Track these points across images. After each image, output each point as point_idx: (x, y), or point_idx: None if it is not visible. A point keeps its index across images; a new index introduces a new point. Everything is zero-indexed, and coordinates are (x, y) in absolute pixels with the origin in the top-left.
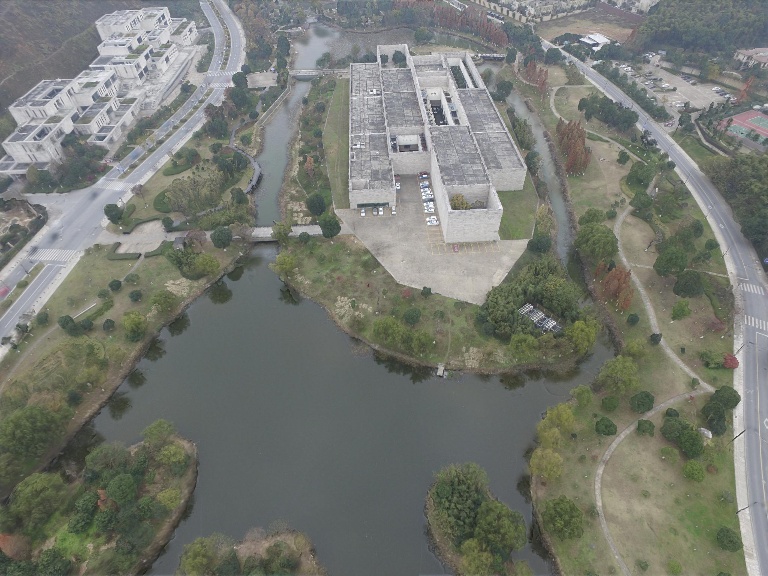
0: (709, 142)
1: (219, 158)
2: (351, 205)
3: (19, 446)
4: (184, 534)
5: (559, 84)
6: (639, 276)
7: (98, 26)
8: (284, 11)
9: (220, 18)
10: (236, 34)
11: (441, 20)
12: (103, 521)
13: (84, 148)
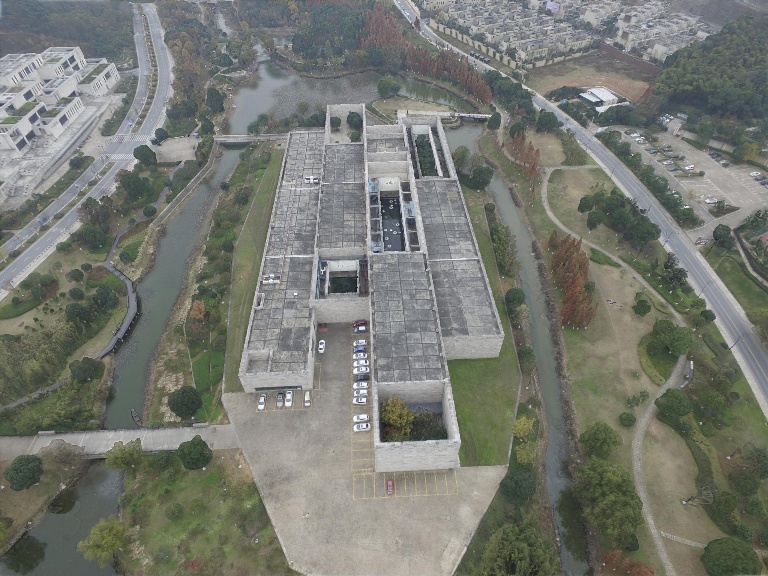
0: (758, 273)
1: (78, 292)
2: (246, 389)
3: None
4: None
5: (554, 163)
6: (676, 565)
7: None
8: (230, 47)
9: (150, 57)
10: (165, 79)
11: (413, 64)
12: None
13: None
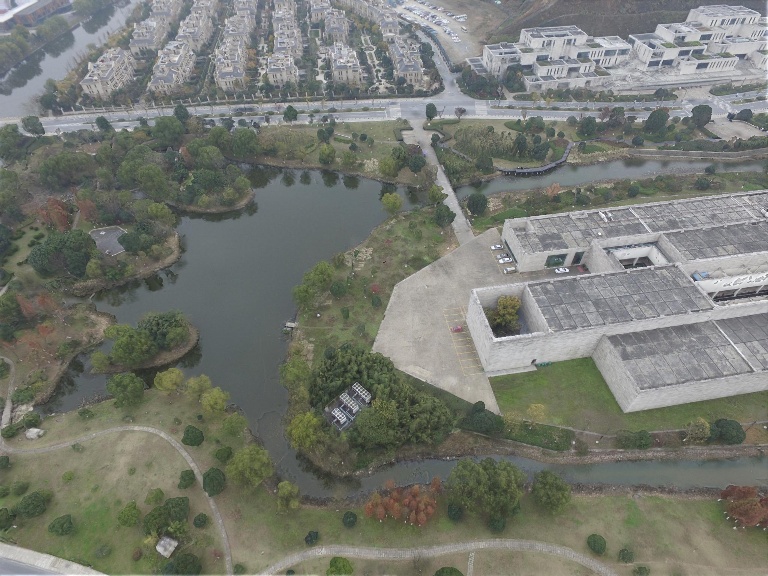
0: None
1: (538, 139)
2: (502, 235)
3: (234, 139)
4: (201, 225)
5: None
6: (444, 559)
7: (693, 10)
8: None
9: None
10: None
11: None
12: (193, 180)
13: (513, 78)
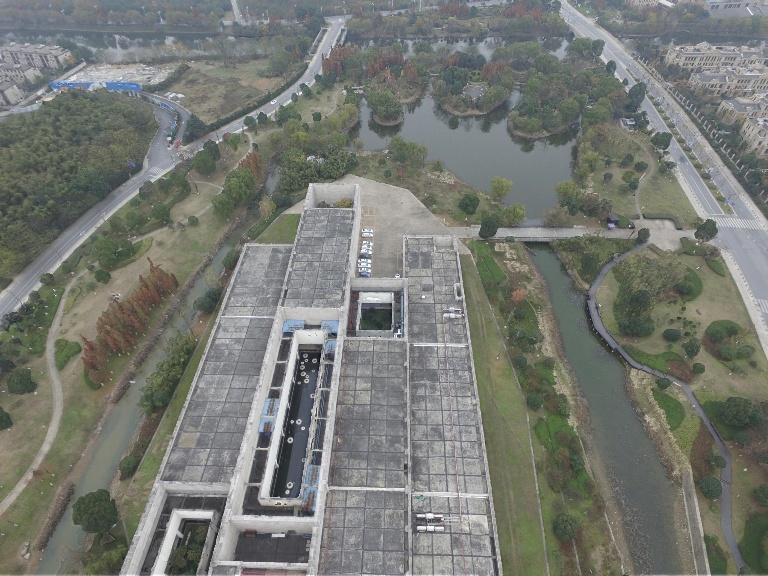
0: None
1: (669, 331)
2: None
3: None
4: None
5: None
6: None
7: None
8: None
9: None
10: None
11: None
12: None
13: None
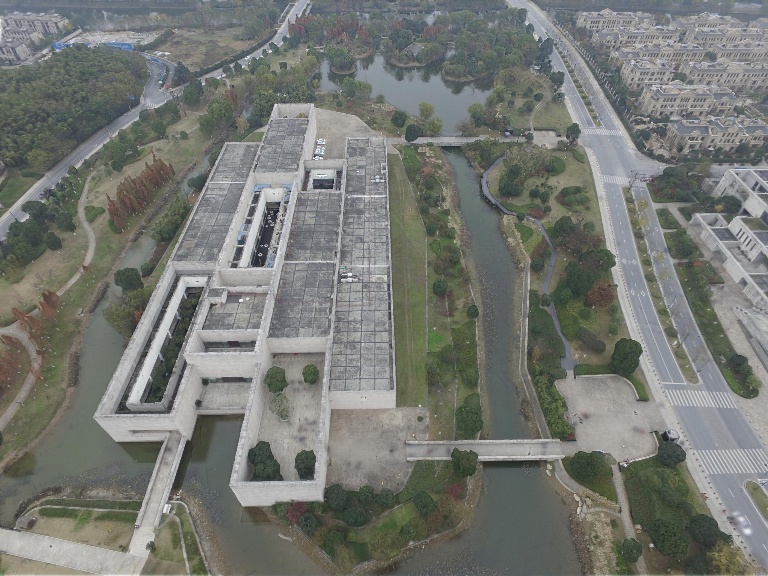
0: None
1: (532, 190)
2: None
3: None
4: None
5: None
6: None
7: None
8: None
9: None
10: None
11: None
12: None
13: (704, 201)
